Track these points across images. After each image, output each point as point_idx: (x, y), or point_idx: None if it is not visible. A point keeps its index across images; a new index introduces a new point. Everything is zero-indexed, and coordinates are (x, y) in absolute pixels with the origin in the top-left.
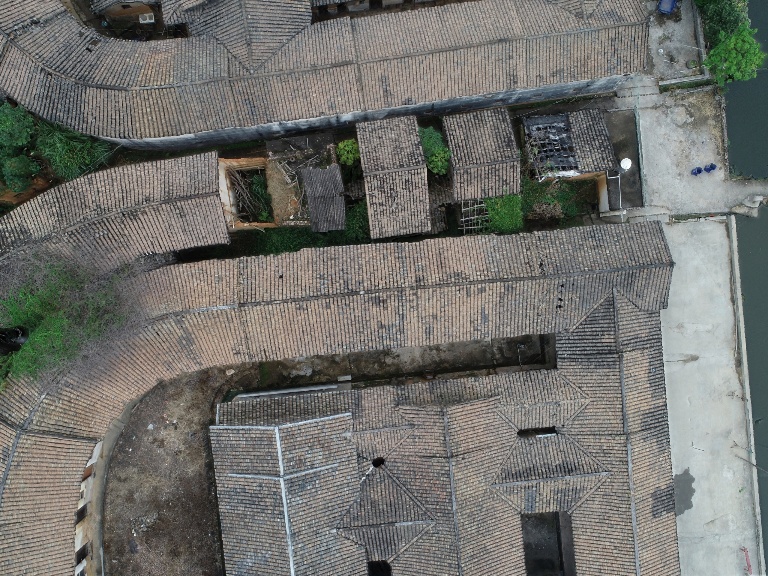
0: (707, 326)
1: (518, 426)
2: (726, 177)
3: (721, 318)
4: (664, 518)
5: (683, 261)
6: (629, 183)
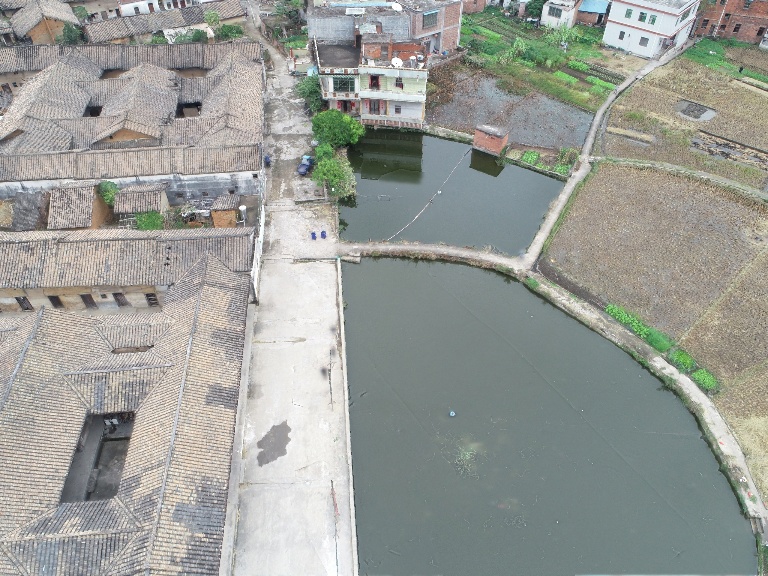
0: (315, 320)
1: (113, 344)
2: (337, 241)
3: (327, 316)
4: (220, 410)
5: (301, 283)
6: (251, 225)
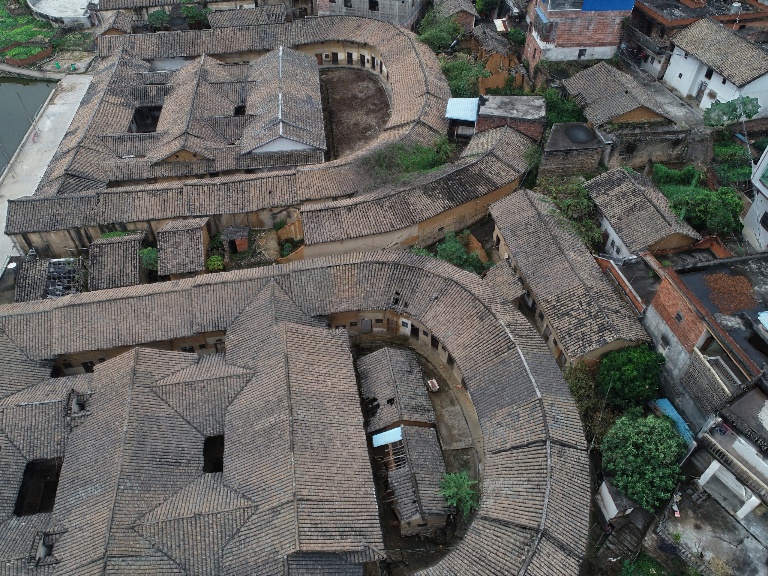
0: None
1: None
2: None
3: None
4: None
5: None
6: None
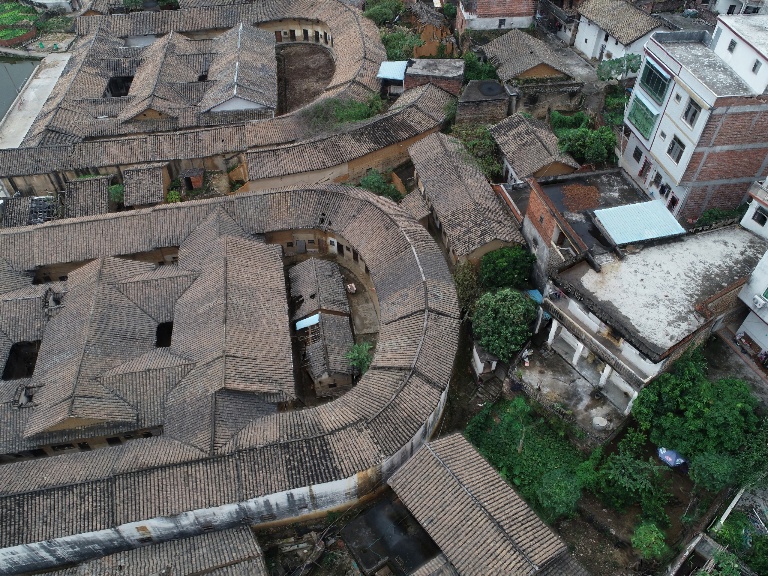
0: None
1: None
2: None
3: None
4: None
5: None
6: None
